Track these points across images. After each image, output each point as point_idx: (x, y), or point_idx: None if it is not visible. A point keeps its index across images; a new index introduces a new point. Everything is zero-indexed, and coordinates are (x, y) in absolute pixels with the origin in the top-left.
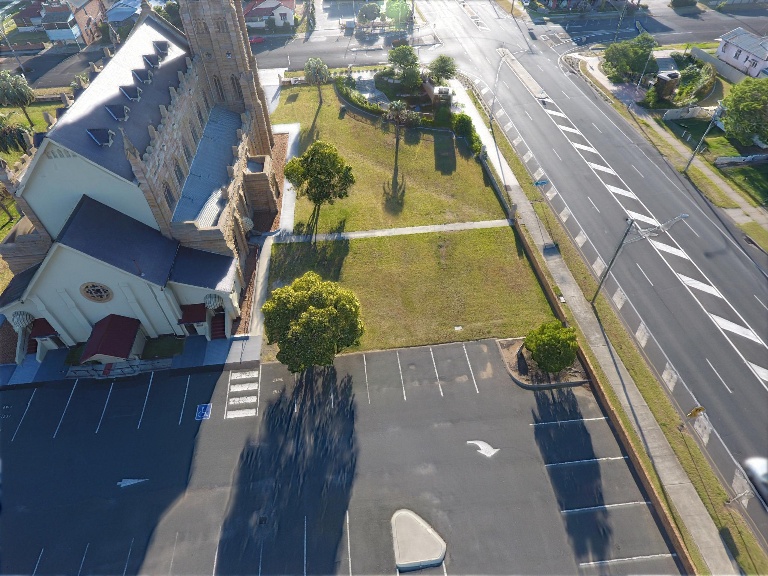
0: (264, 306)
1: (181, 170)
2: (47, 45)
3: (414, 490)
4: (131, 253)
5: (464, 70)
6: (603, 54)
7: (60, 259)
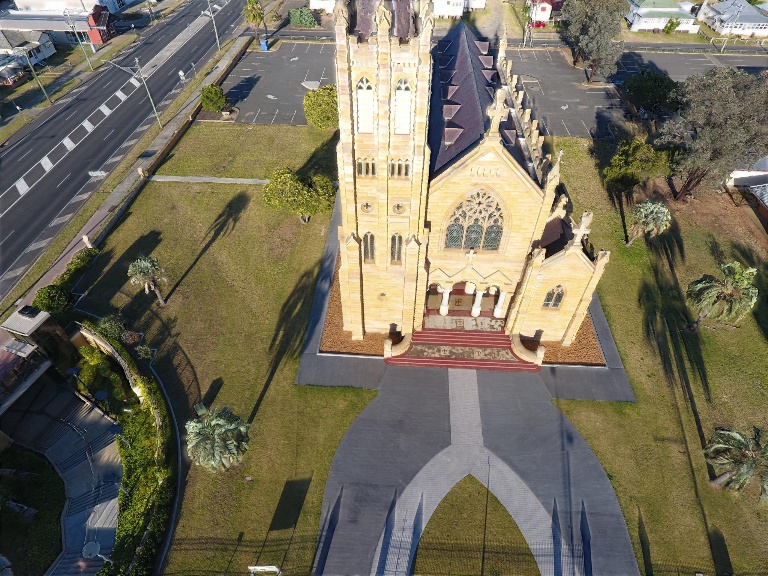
0: None
1: None
2: None
3: (306, 92)
4: None
5: None
6: None
7: None
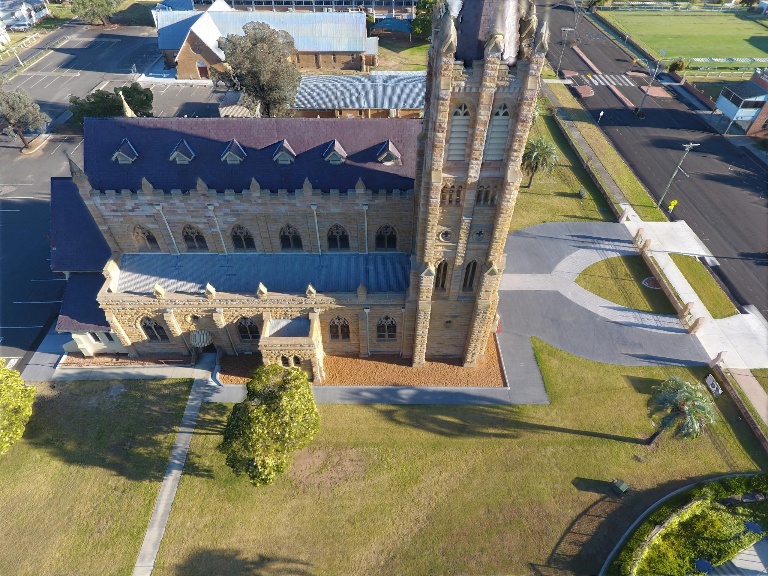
0: None
1: (207, 242)
2: None
3: None
4: (74, 232)
5: None
6: None
7: None
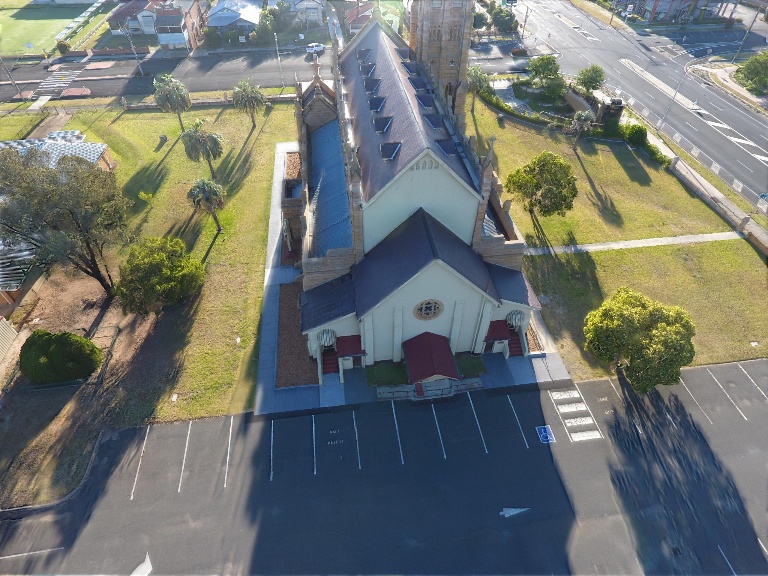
0: (599, 323)
1: None
2: (152, 49)
3: None
4: (471, 269)
5: None
6: (727, 66)
7: (422, 276)
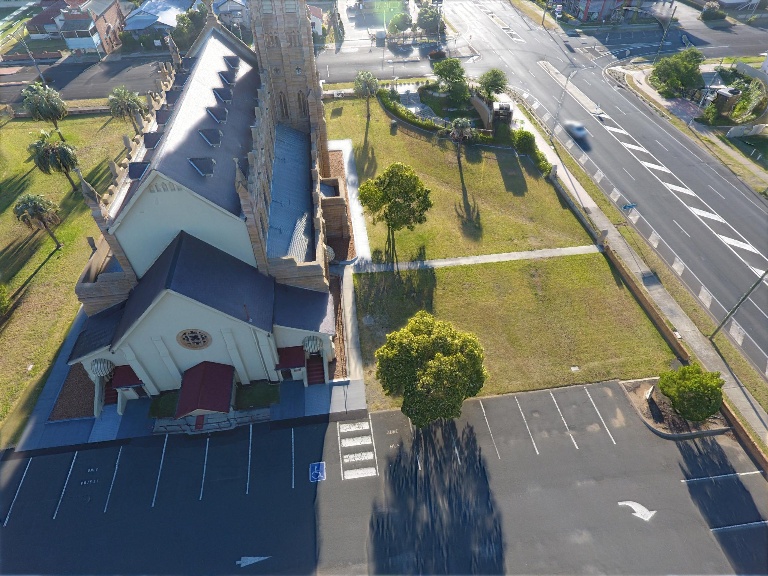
0: (381, 352)
1: (266, 197)
2: (64, 54)
3: (574, 563)
4: (235, 296)
5: (509, 83)
6: (646, 68)
7: (164, 306)
